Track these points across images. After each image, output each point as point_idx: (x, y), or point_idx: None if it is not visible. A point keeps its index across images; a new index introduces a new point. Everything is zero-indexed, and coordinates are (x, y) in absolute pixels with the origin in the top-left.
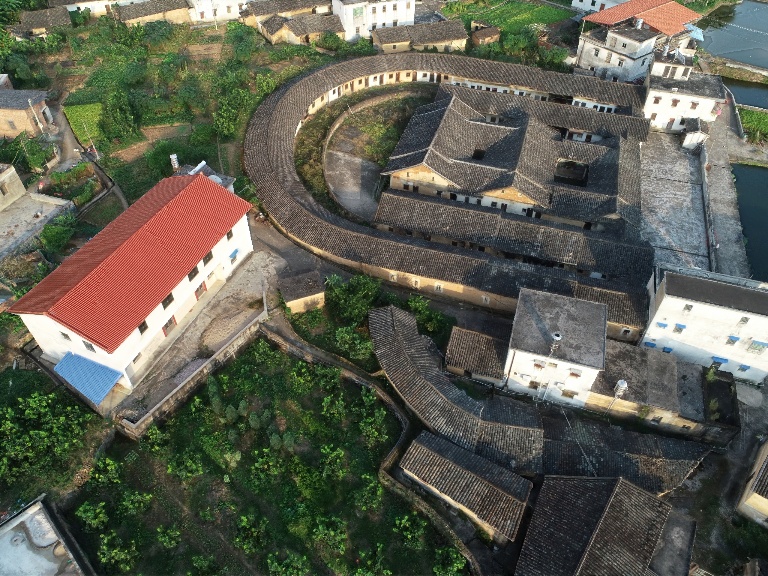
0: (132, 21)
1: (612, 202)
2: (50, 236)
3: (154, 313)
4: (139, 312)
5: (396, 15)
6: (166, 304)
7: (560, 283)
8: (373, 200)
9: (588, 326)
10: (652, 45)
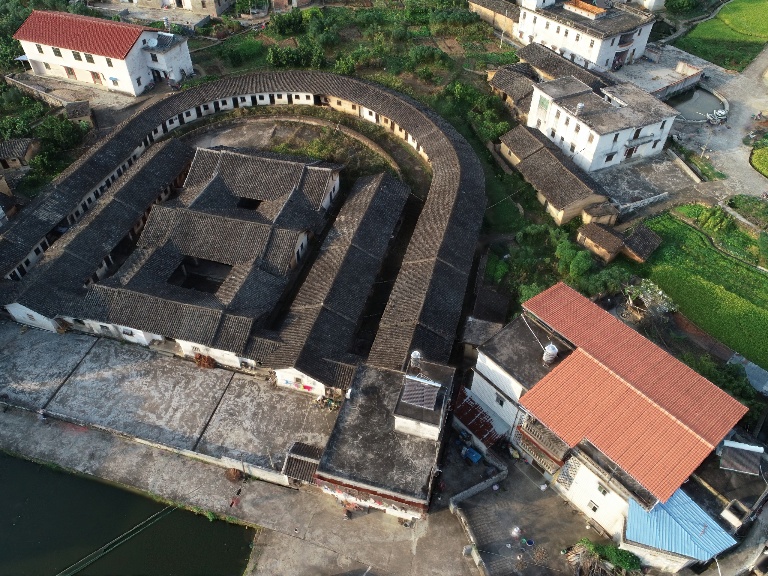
0: (474, 5)
1: None
2: (155, 25)
3: (48, 50)
4: (36, 38)
5: (576, 139)
6: (57, 54)
7: None
8: None
9: None
10: (517, 392)
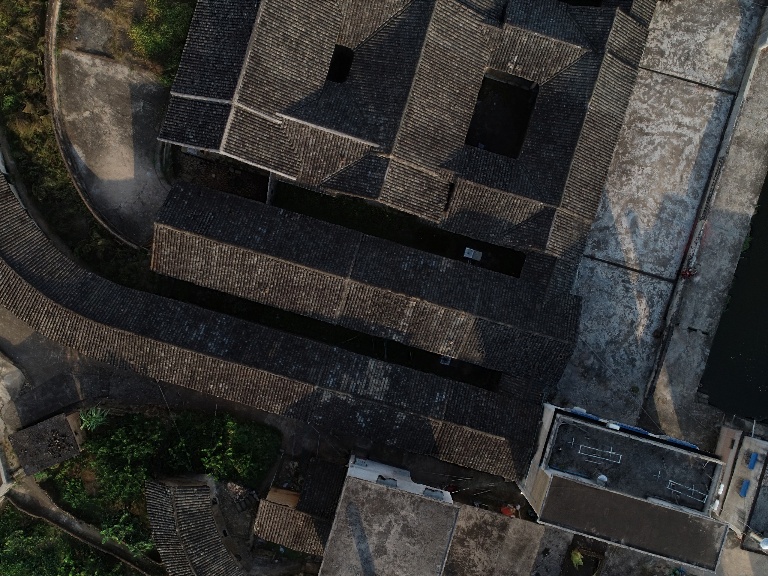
0: None
1: (546, 220)
2: None
3: None
4: None
5: None
6: None
7: (418, 421)
8: (158, 176)
9: (426, 546)
10: None
